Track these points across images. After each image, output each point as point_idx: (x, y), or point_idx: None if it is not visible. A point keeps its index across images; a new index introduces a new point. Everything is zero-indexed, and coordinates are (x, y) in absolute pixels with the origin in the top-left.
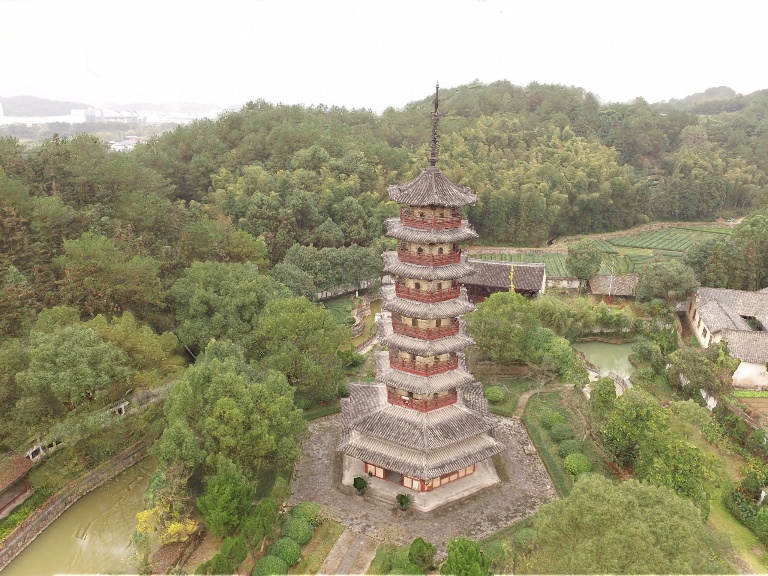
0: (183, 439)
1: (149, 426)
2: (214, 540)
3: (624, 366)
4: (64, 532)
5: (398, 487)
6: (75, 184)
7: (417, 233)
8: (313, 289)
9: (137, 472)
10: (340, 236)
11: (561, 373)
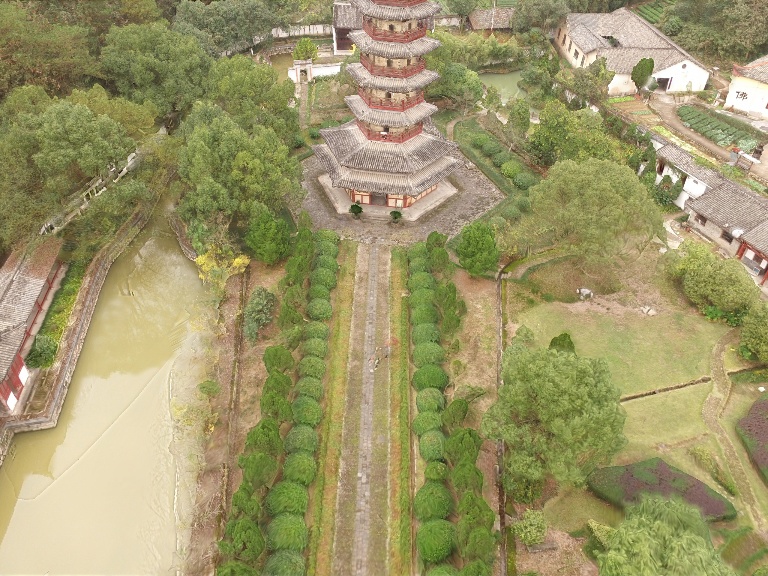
0: (218, 192)
1: (168, 189)
2: (261, 269)
3: (509, 93)
4: (109, 294)
5: (384, 208)
6: None
7: None
8: (216, 49)
9: (158, 234)
10: None
11: (474, 103)
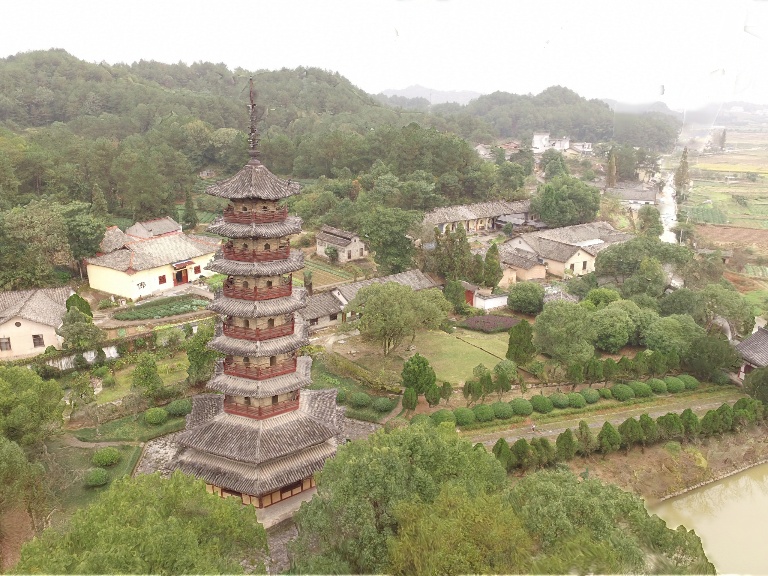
0: None
1: None
2: None
3: None
4: None
5: None
6: None
7: None
8: None
9: None
10: None
11: None
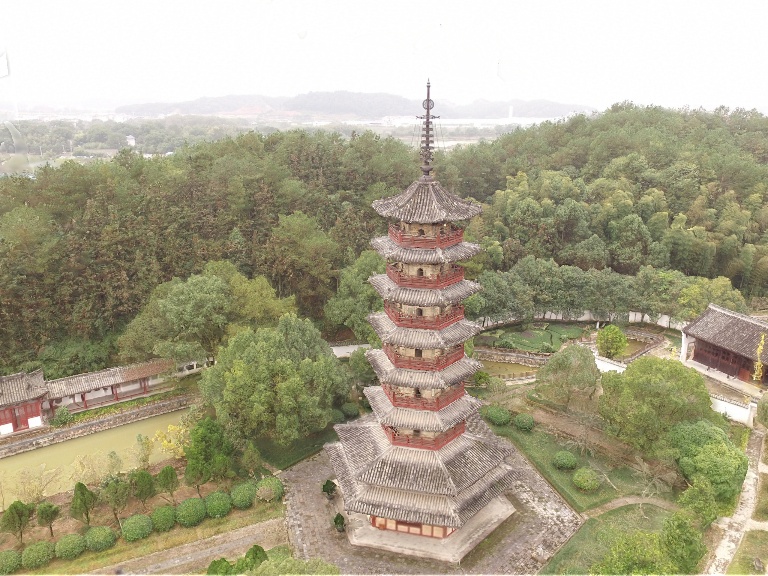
0: None
1: None
2: None
3: None
4: None
5: None
6: (342, 172)
7: (393, 247)
8: (527, 305)
9: None
10: (601, 257)
11: None
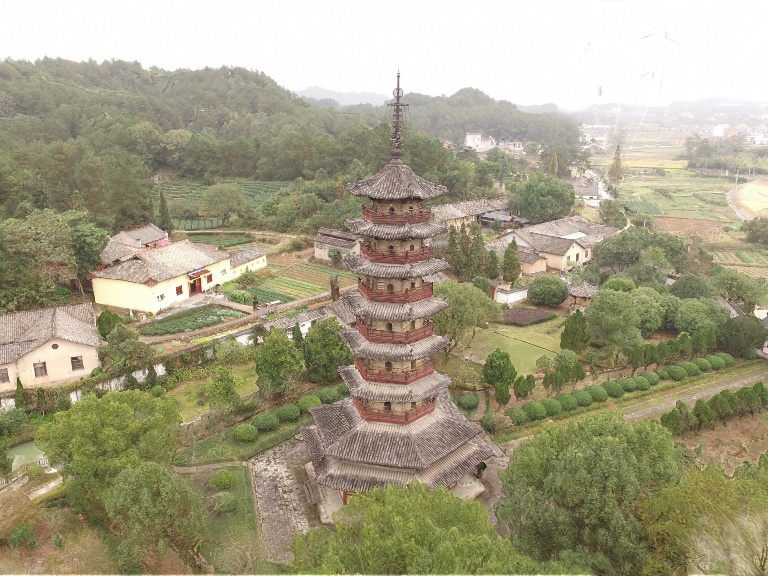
0: None
1: None
2: None
3: None
4: None
5: None
6: None
7: None
8: None
9: None
10: None
11: None
